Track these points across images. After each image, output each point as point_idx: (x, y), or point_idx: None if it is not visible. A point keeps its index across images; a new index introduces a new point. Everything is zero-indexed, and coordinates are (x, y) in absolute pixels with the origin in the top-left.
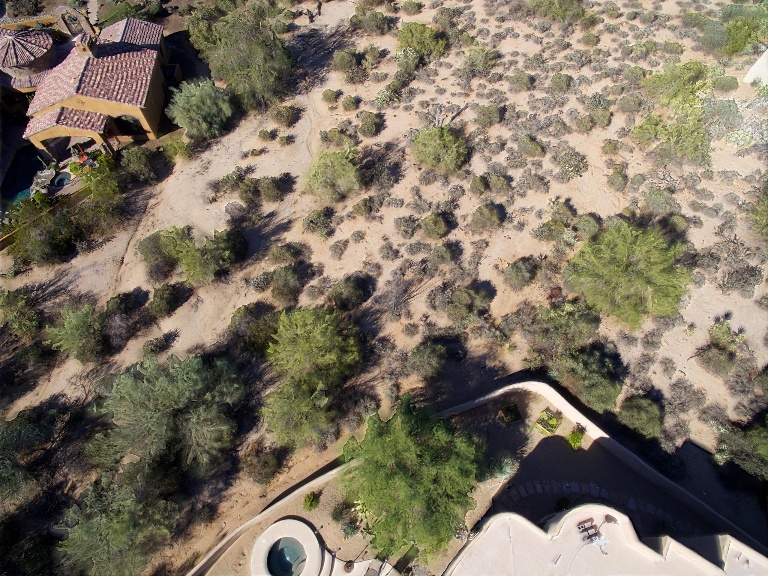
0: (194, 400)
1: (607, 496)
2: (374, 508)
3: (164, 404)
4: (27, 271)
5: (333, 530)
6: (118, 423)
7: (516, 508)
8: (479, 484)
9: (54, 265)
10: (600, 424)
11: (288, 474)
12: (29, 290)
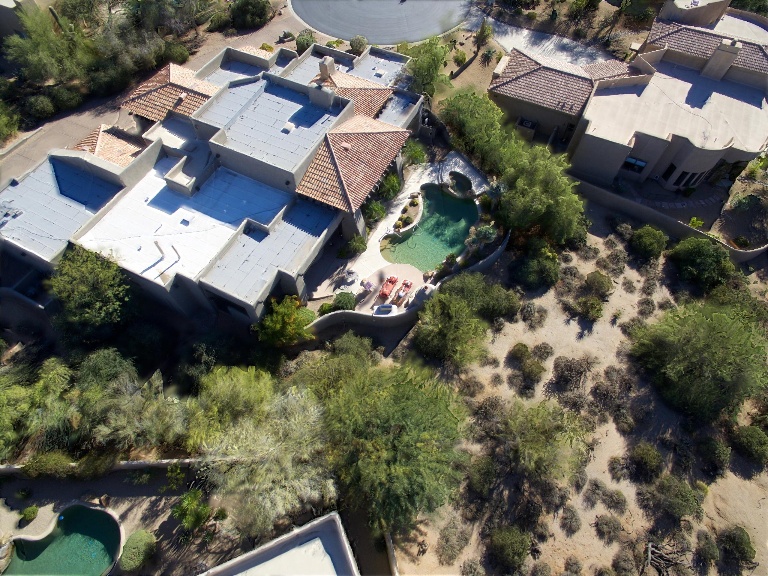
0: None
1: (657, 203)
2: None
3: None
4: None
5: None
6: None
7: (714, 192)
8: None
9: None
10: (672, 244)
11: None
12: None
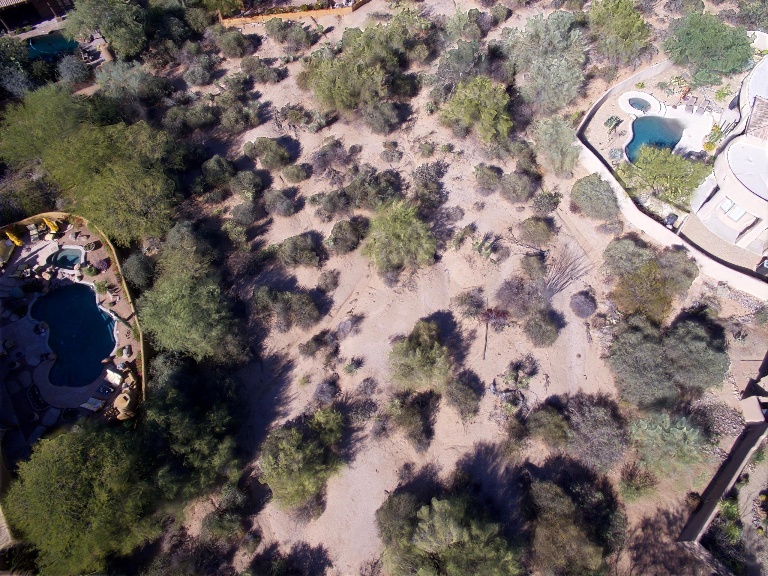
0: (566, 33)
1: None
2: (700, 56)
3: (554, 31)
4: (400, 6)
5: (660, 94)
6: (517, 53)
7: None
8: (732, 77)
9: (416, 3)
10: None
11: (617, 81)
12: (407, 14)
